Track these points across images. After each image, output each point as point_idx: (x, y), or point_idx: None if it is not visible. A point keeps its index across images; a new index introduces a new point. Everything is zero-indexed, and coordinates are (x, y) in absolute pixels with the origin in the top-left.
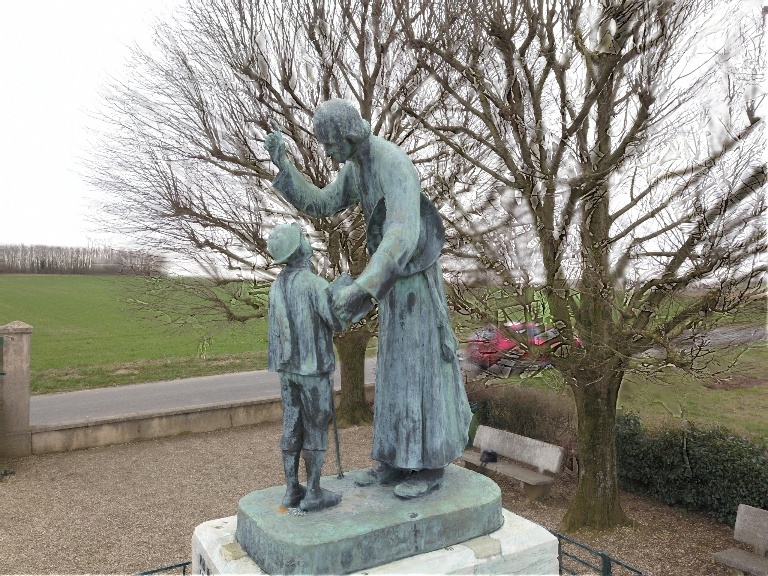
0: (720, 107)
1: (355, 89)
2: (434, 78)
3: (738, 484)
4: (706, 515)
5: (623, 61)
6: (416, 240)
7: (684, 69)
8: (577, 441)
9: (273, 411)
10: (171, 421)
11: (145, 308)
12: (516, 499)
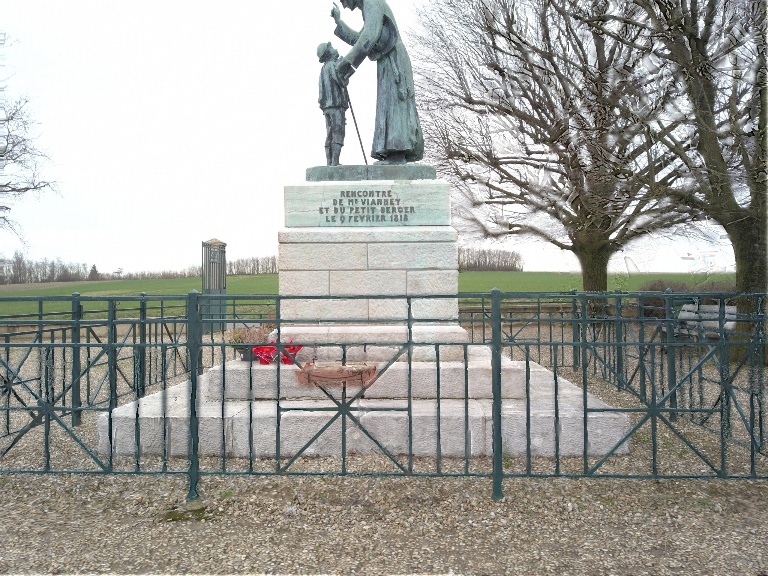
0: None
1: None
2: None
3: None
4: None
5: None
6: (376, 36)
7: None
8: None
9: (527, 316)
10: None
11: None
12: (694, 356)
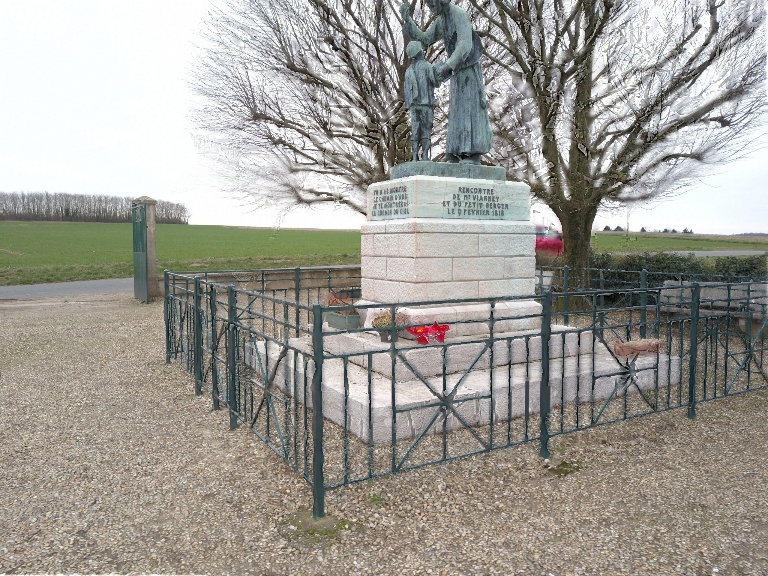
0: (657, 10)
1: (398, 14)
2: None
3: None
4: None
5: None
6: (470, 48)
7: None
8: (563, 259)
9: None
10: None
11: (236, 189)
12: None
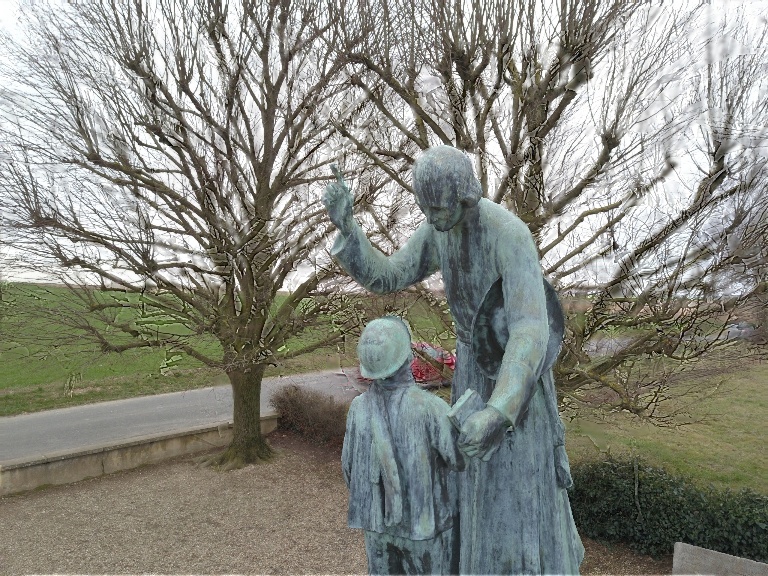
0: None
1: (256, 96)
2: (368, 97)
3: (660, 516)
4: (627, 546)
5: (553, 96)
6: (547, 339)
7: (641, 114)
8: None
9: (153, 452)
10: (26, 474)
11: None
12: None
